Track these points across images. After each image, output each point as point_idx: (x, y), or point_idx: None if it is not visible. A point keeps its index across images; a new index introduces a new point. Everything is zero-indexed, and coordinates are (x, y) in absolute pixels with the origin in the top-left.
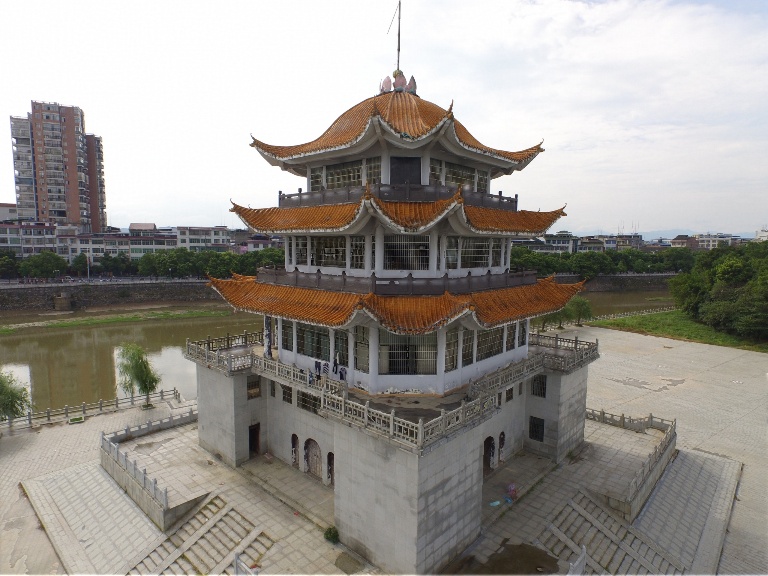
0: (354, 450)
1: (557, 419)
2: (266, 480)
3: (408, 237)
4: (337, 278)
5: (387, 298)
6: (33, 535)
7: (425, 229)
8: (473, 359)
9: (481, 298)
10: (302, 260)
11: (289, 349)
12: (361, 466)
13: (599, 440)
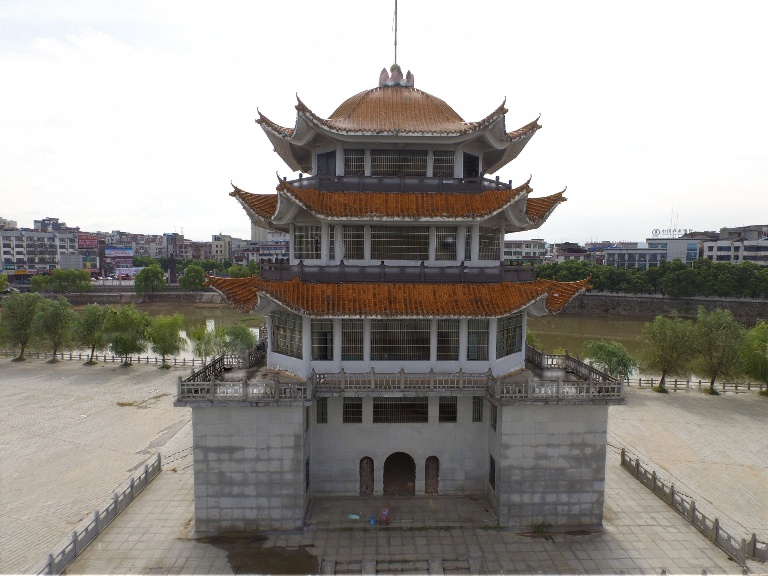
0: None
1: (500, 464)
2: None
3: (308, 228)
4: None
5: (266, 282)
6: (183, 423)
7: (286, 218)
8: (364, 356)
9: (355, 289)
10: None
11: None
12: None
13: (628, 535)
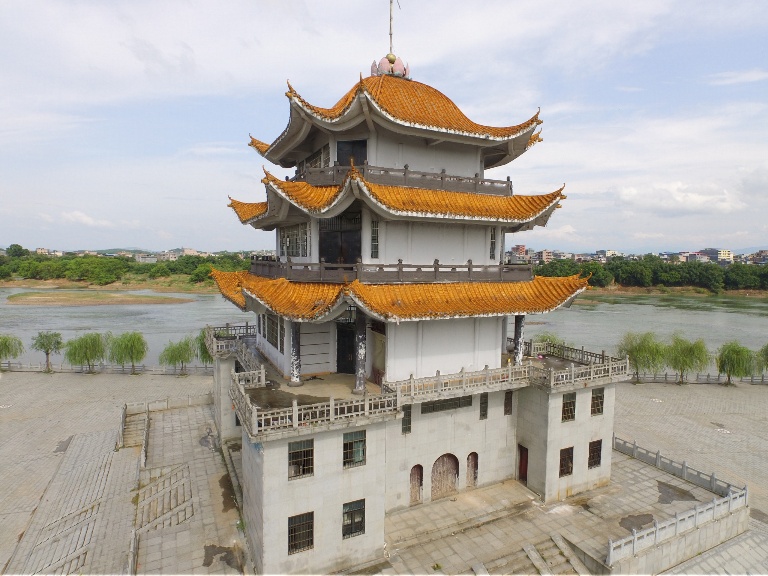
0: None
1: None
2: None
3: None
4: None
5: None
6: None
7: None
8: None
9: None
10: None
11: None
12: None
13: (202, 419)
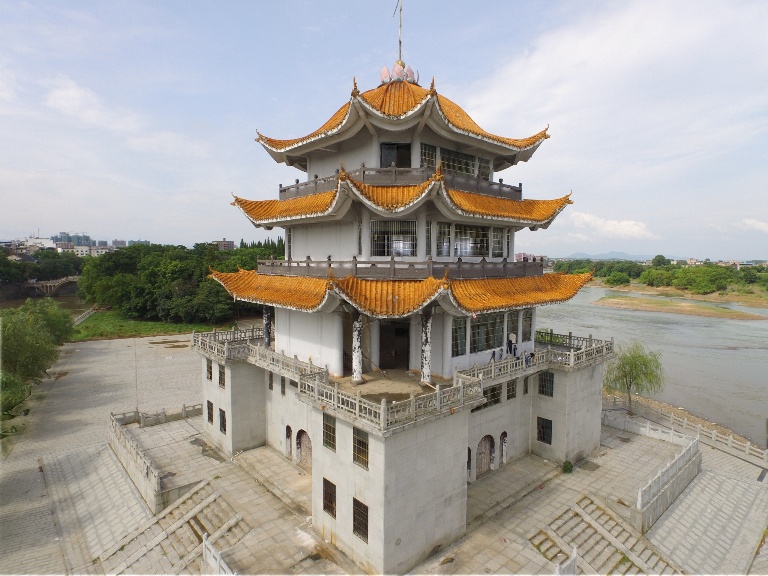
0: (578, 387)
1: None
2: (497, 502)
3: None
4: (521, 265)
5: None
6: None
7: None
8: None
9: None
10: (444, 251)
11: (461, 354)
12: (581, 395)
13: None
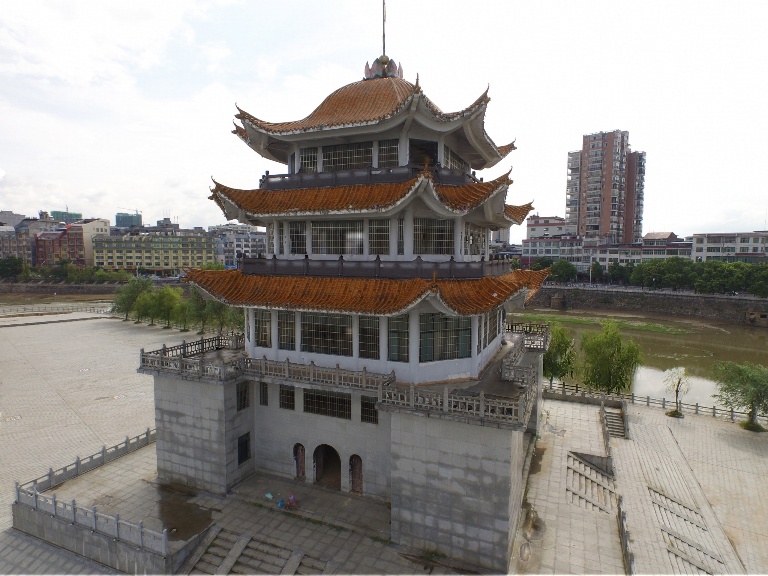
0: None
1: None
2: None
3: None
4: None
5: None
6: None
7: None
8: (296, 346)
9: (280, 282)
10: None
11: None
12: None
13: None
